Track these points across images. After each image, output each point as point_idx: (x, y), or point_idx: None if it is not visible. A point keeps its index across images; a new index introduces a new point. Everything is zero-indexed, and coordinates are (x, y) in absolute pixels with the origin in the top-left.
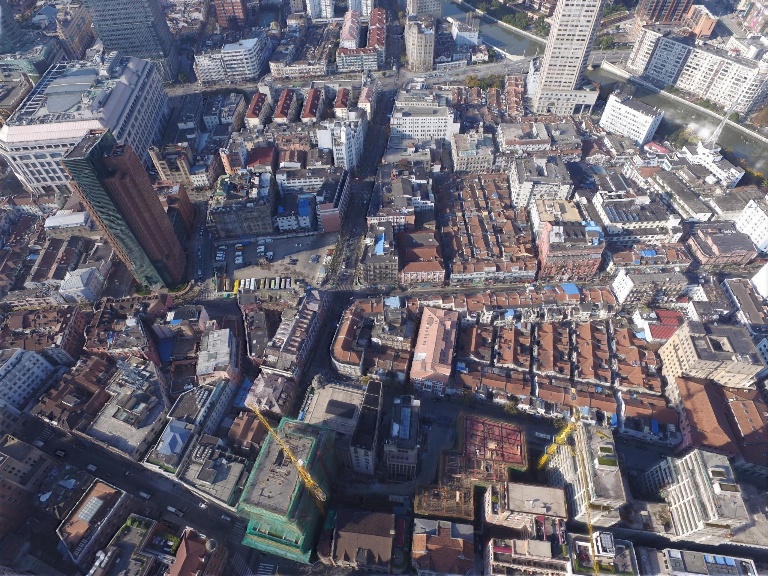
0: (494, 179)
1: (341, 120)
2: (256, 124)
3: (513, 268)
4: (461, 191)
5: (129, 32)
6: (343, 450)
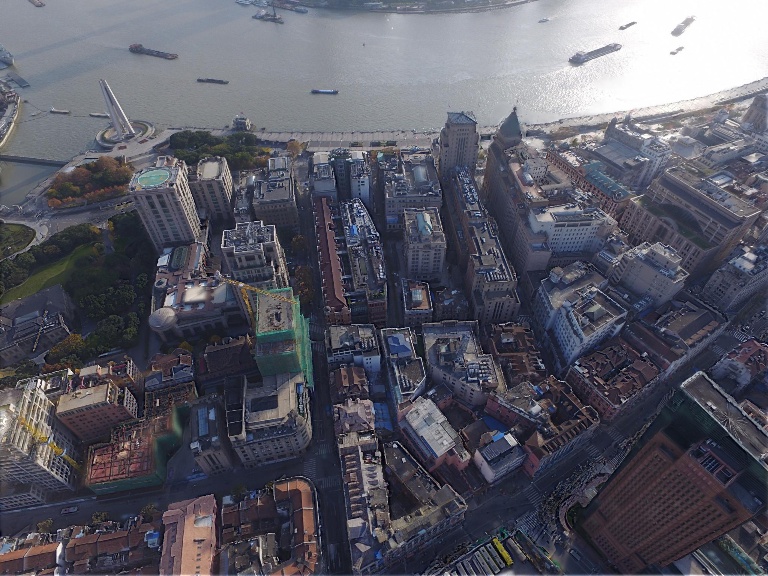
0: None
1: None
2: None
3: None
4: None
5: None
6: (256, 383)
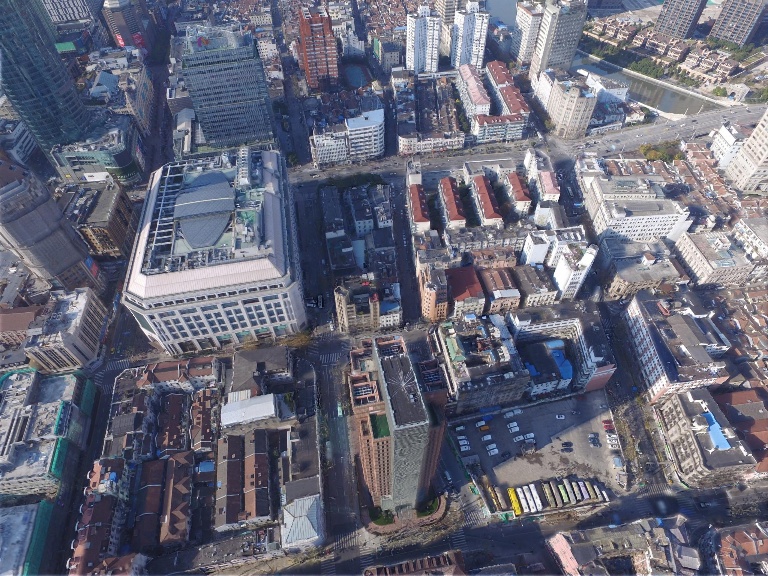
0: (764, 296)
1: (520, 214)
2: (426, 228)
3: None
4: (736, 319)
5: (236, 112)
6: None
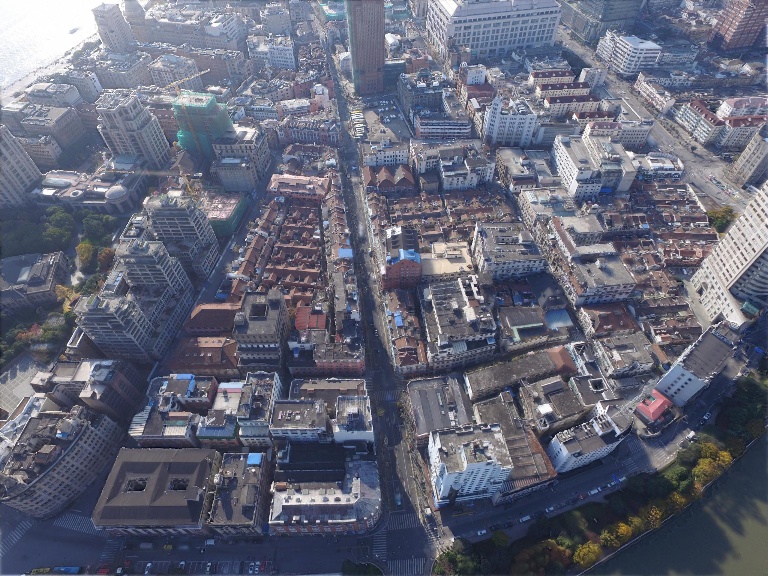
0: None
1: None
2: (530, 82)
3: (373, 225)
4: None
5: None
6: None
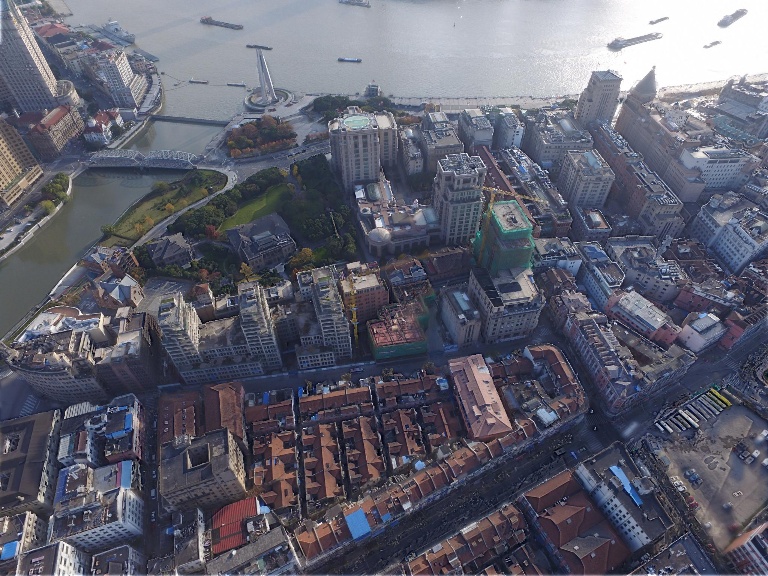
0: None
1: None
2: None
3: None
4: None
5: None
6: None
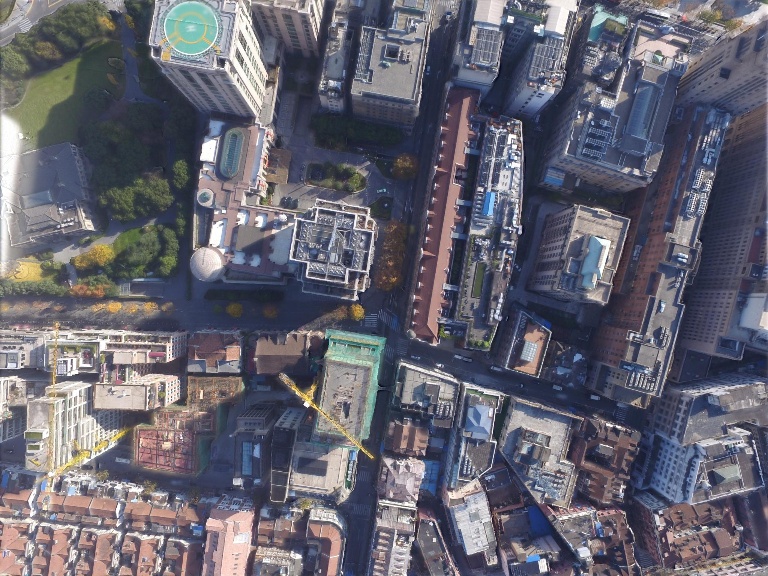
0: None
1: None
2: None
3: None
4: None
5: None
6: (307, 425)
